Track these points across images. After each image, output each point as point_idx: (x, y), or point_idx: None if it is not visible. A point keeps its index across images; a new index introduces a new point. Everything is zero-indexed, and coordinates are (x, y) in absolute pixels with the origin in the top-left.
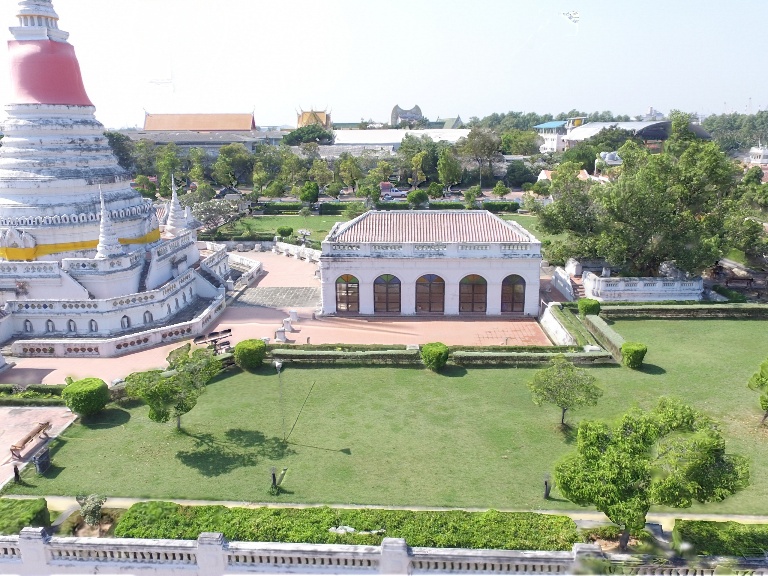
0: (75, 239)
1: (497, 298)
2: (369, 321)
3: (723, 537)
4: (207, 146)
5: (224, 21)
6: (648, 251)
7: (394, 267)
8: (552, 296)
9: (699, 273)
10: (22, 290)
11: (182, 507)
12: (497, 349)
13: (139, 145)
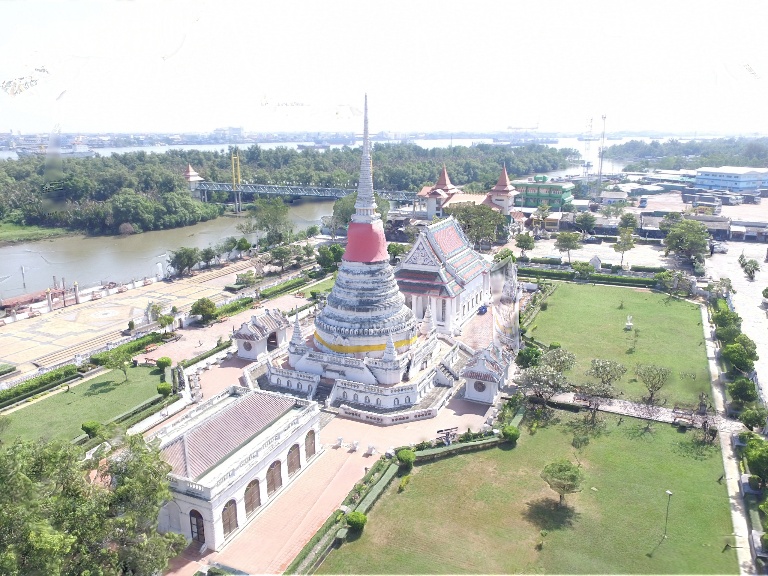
0: None
1: None
2: None
3: None
4: None
5: None
6: None
7: None
8: None
9: None
10: None
11: (65, 369)
12: None
13: None
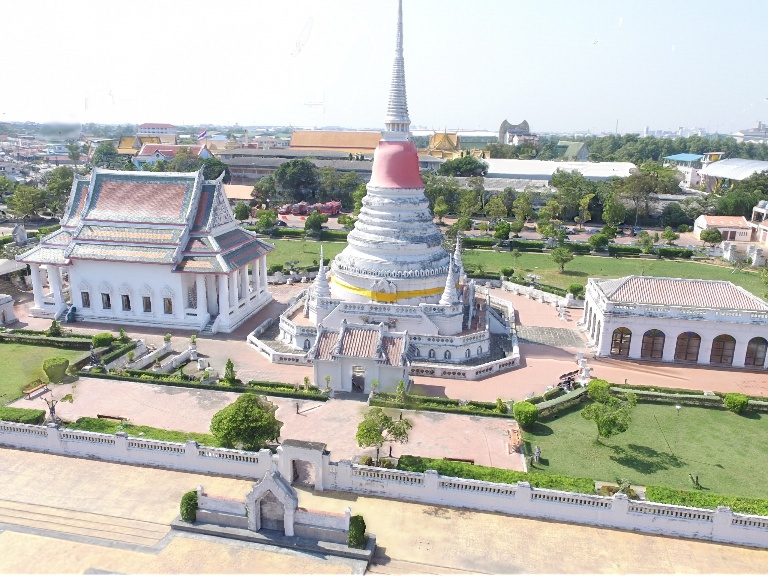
0: (421, 288)
1: (743, 354)
2: (640, 364)
3: None
4: None
5: (372, 49)
6: None
7: (662, 324)
8: None
9: None
10: (393, 325)
11: (679, 491)
12: None
13: (326, 172)
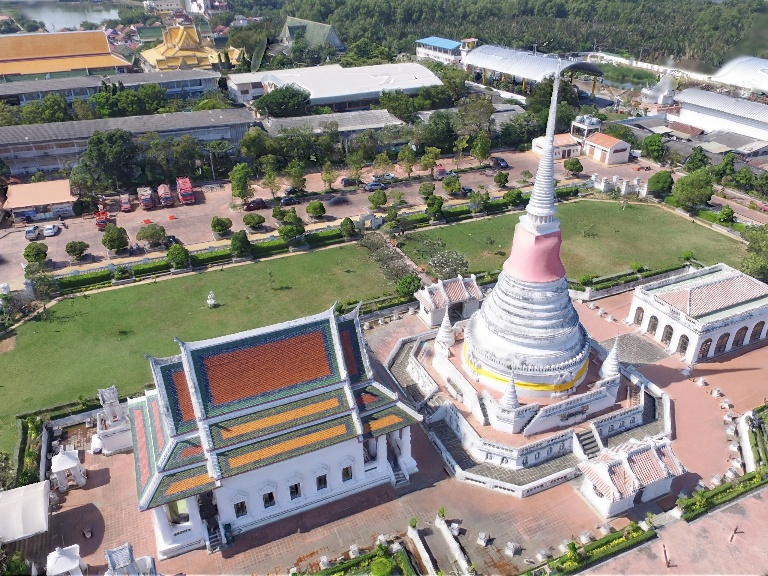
0: None
1: (766, 330)
2: (721, 363)
3: None
4: (211, 129)
5: None
6: None
7: (730, 328)
8: None
9: None
10: None
11: None
12: None
13: (154, 143)
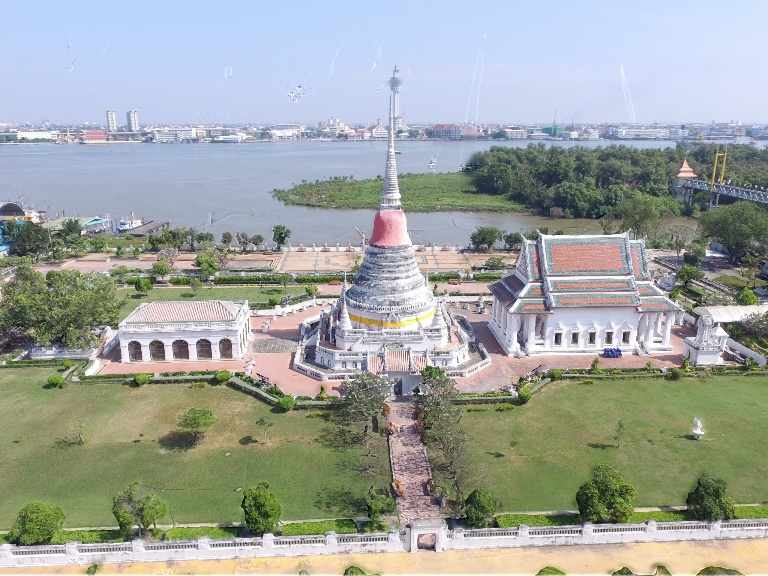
0: None
1: None
2: None
3: None
4: None
5: None
6: None
7: None
8: None
9: None
10: None
11: None
12: None
13: None
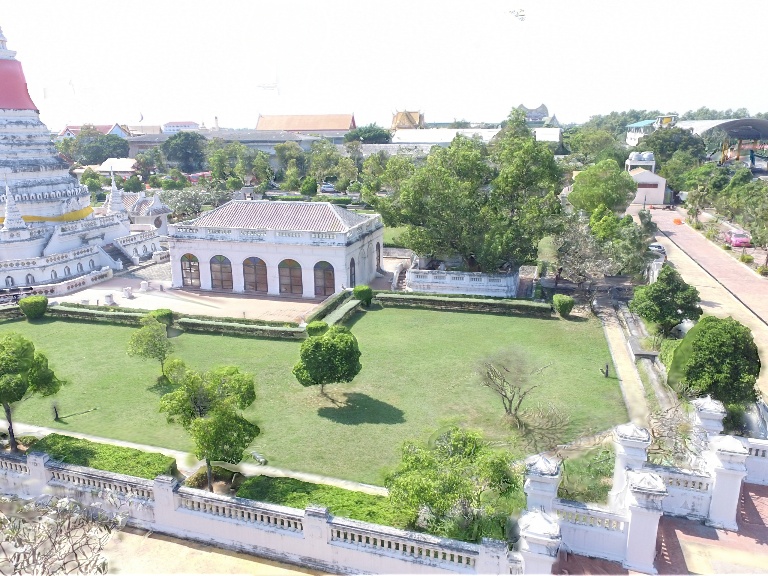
0: None
1: (311, 282)
2: (200, 295)
3: (55, 446)
4: (270, 144)
5: (327, 28)
6: (459, 246)
7: (225, 249)
8: (385, 285)
9: (515, 270)
10: None
11: None
12: (229, 320)
13: (209, 143)
